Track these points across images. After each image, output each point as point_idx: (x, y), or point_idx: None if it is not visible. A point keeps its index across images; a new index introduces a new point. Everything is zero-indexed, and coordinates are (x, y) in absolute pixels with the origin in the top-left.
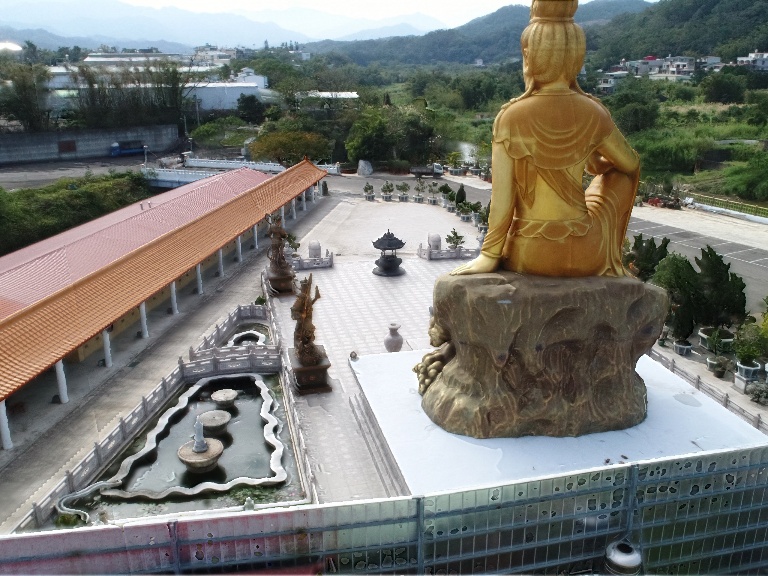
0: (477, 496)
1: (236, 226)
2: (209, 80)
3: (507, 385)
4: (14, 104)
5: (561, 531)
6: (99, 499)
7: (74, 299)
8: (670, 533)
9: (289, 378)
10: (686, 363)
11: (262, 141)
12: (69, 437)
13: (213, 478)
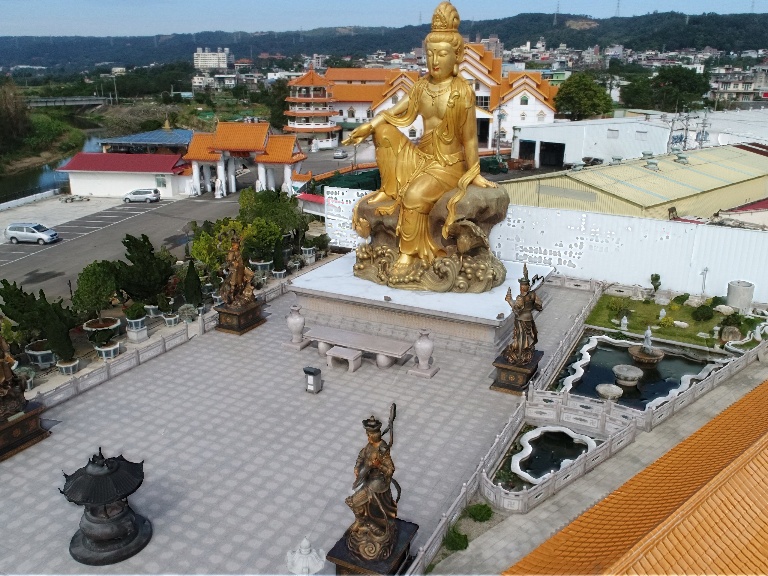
0: None
1: None
2: None
3: None
4: None
5: None
6: None
7: None
8: None
9: None
10: None
11: None
12: None
13: None
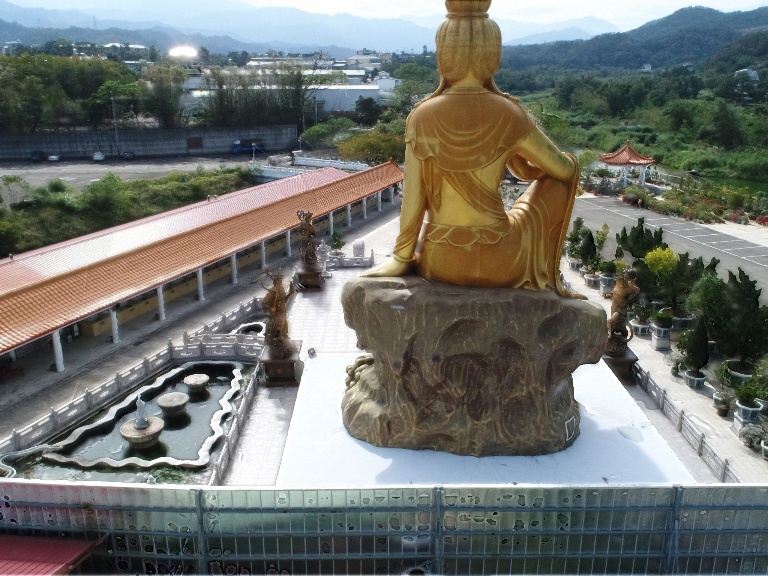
0: (262, 497)
1: (285, 222)
2: (331, 82)
3: (408, 394)
4: (151, 103)
5: (361, 547)
6: (40, 460)
7: (85, 278)
8: (493, 568)
9: (261, 369)
10: (692, 396)
11: (353, 142)
12: (46, 402)
13: (150, 455)
